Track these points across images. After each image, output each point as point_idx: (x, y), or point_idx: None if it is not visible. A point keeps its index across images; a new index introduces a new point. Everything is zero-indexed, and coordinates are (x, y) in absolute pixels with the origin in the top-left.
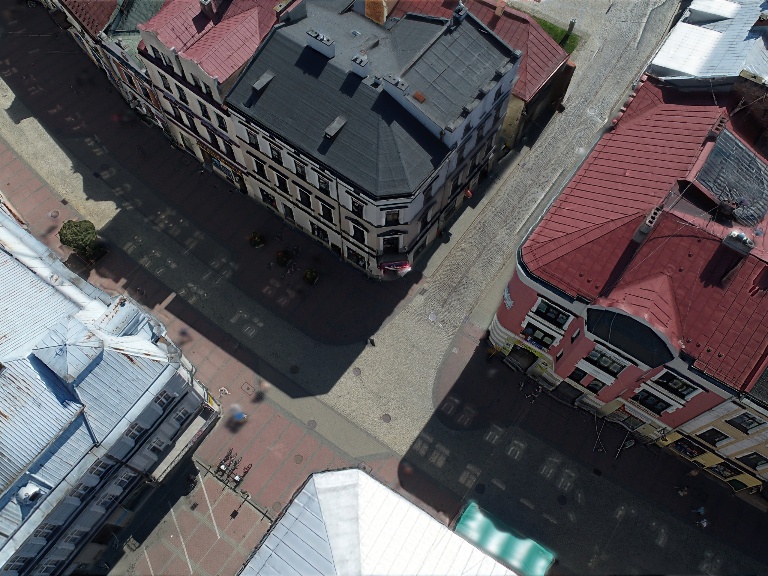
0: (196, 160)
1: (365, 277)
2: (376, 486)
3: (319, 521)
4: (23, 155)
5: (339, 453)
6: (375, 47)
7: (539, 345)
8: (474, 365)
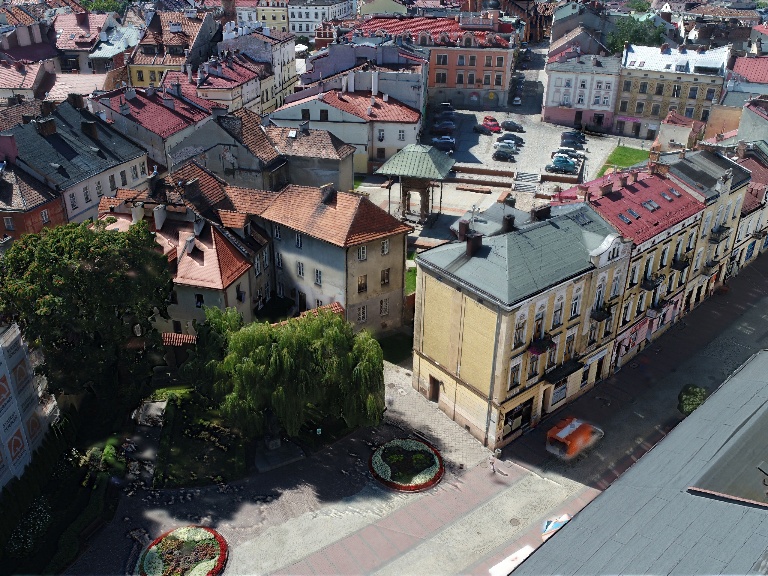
0: None
1: None
2: None
3: None
4: None
5: None
6: None
7: None
8: None
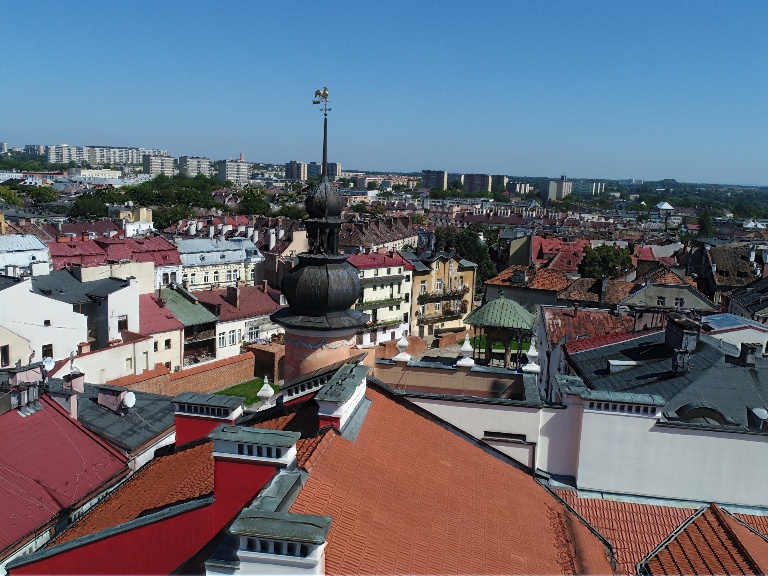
0: None
1: None
2: None
3: None
4: None
5: None
6: (43, 293)
7: None
8: None
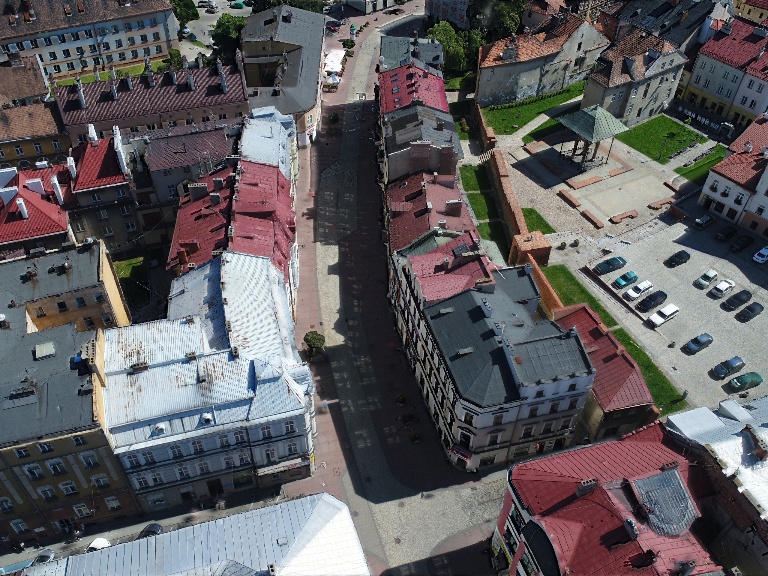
0: (402, 342)
1: (446, 458)
2: (349, 518)
3: (311, 510)
4: (320, 291)
5: None
6: (519, 327)
7: (510, 549)
8: (472, 549)
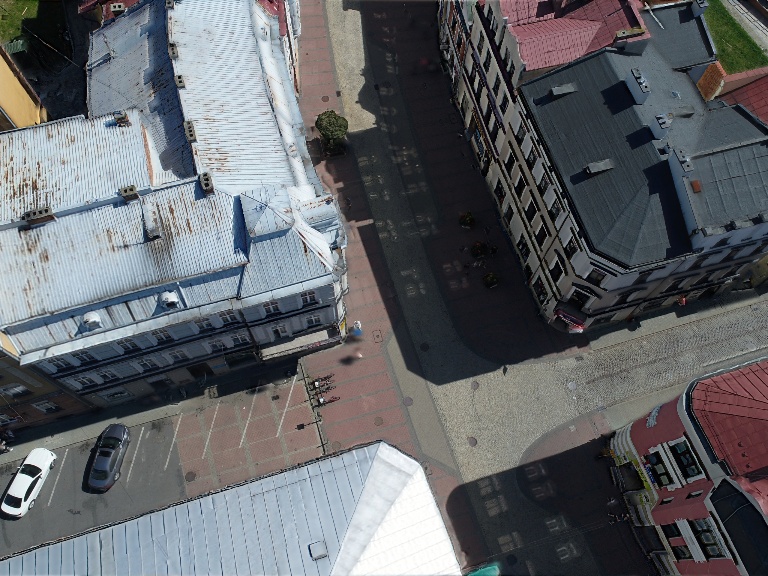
0: (462, 123)
1: (537, 311)
2: (425, 489)
3: (361, 481)
4: (333, 37)
5: (414, 440)
6: (686, 117)
7: (653, 478)
8: (581, 452)
